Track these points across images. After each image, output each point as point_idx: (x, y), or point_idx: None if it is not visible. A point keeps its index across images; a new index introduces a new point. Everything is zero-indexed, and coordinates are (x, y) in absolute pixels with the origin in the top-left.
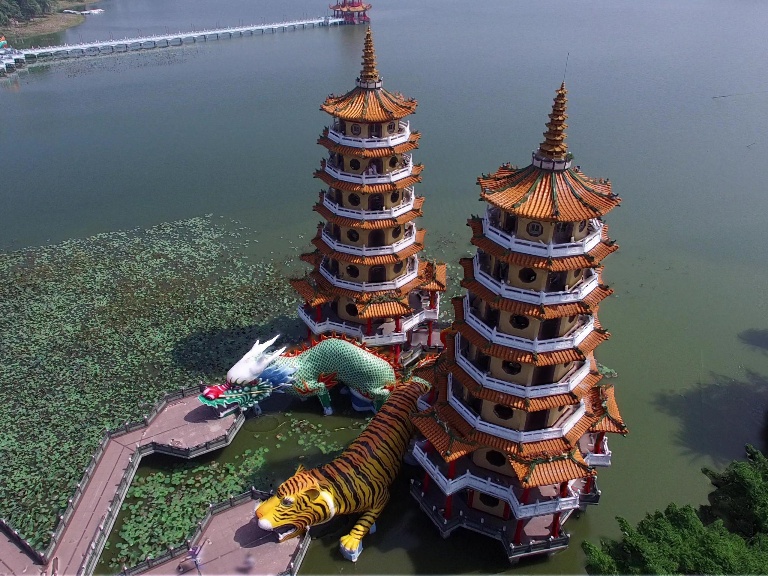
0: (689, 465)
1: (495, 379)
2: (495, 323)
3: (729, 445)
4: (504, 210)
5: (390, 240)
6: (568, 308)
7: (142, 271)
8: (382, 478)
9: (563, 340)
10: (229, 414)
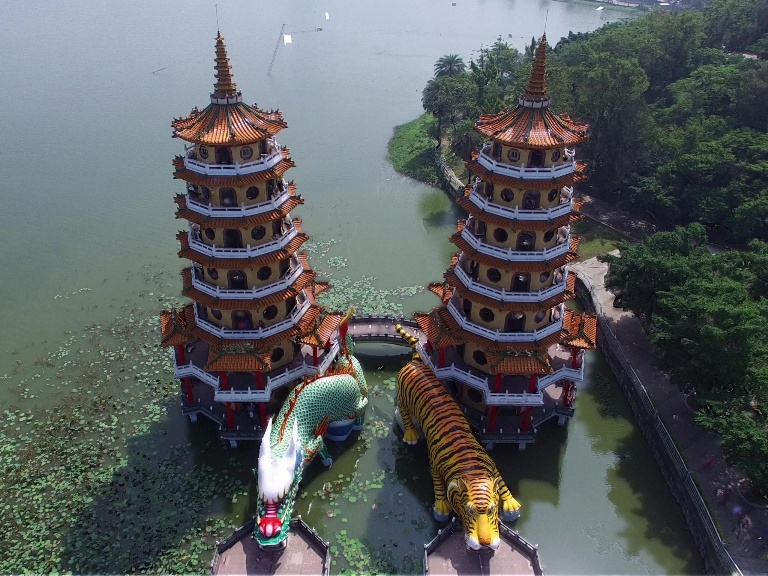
0: None
1: (546, 290)
2: (531, 248)
3: None
4: None
5: (289, 261)
6: (575, 206)
7: None
8: None
9: None
10: None
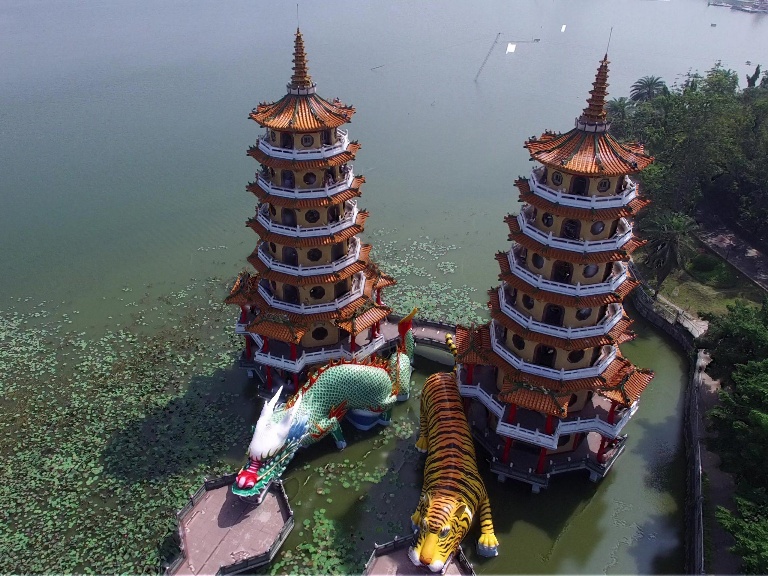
0: None
1: (579, 329)
2: (567, 280)
3: None
4: None
5: (347, 249)
6: (630, 245)
7: None
8: (476, 469)
9: (622, 274)
10: (265, 496)
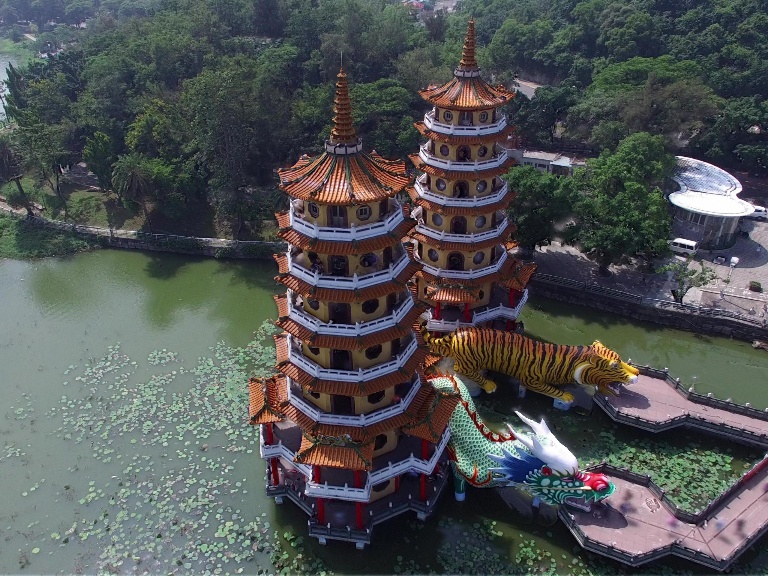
0: None
1: None
2: None
3: None
4: None
5: None
6: None
7: None
8: None
9: None
10: None
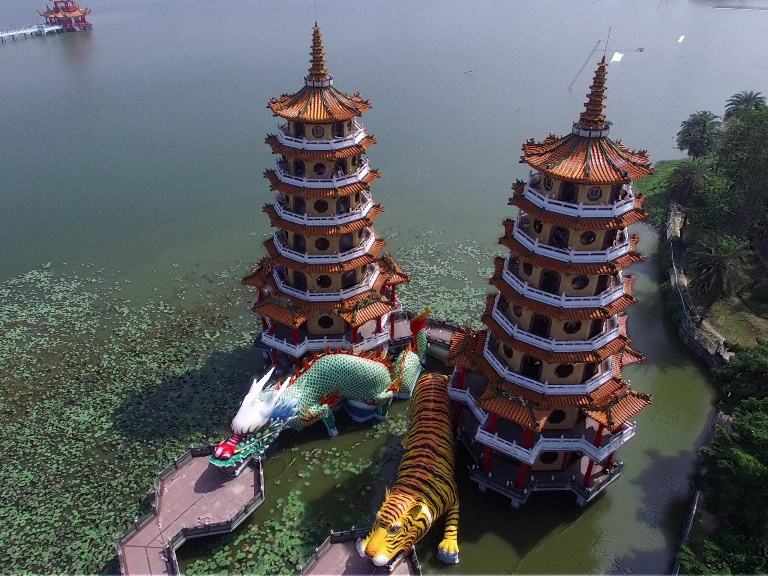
0: (646, 377)
1: (564, 342)
2: (554, 290)
3: (659, 352)
4: (574, 181)
5: (357, 241)
6: (624, 260)
7: (5, 347)
8: (450, 473)
9: (617, 290)
10: (243, 469)
